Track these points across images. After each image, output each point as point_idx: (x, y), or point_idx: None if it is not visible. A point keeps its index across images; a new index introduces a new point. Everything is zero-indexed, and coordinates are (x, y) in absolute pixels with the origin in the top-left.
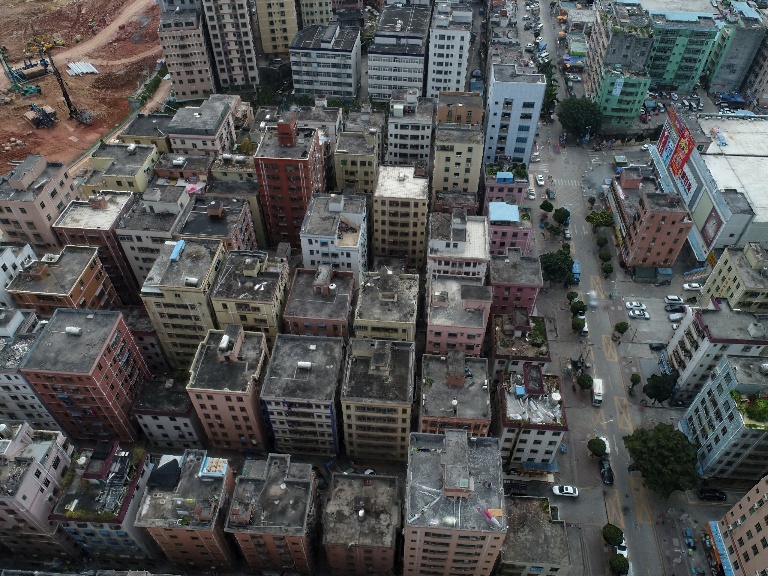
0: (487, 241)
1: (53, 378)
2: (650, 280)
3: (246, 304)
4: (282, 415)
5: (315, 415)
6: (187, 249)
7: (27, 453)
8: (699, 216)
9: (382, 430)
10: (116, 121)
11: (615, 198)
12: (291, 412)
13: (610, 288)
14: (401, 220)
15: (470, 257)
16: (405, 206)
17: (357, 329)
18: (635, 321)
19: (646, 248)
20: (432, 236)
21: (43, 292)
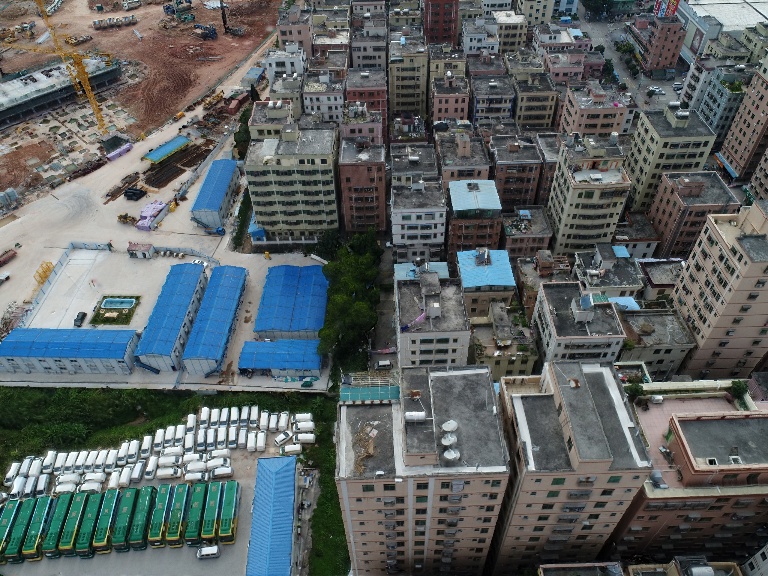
0: (572, 36)
1: (363, 94)
2: (662, 78)
3: (450, 63)
4: (483, 112)
5: (502, 110)
6: (407, 42)
7: None
8: (688, 39)
9: (537, 118)
10: (259, 33)
11: (633, 35)
12: (489, 109)
13: (638, 83)
14: (511, 40)
15: (565, 42)
16: (514, 29)
17: (510, 77)
18: (657, 96)
19: (658, 54)
20: (541, 33)
21: (330, 68)
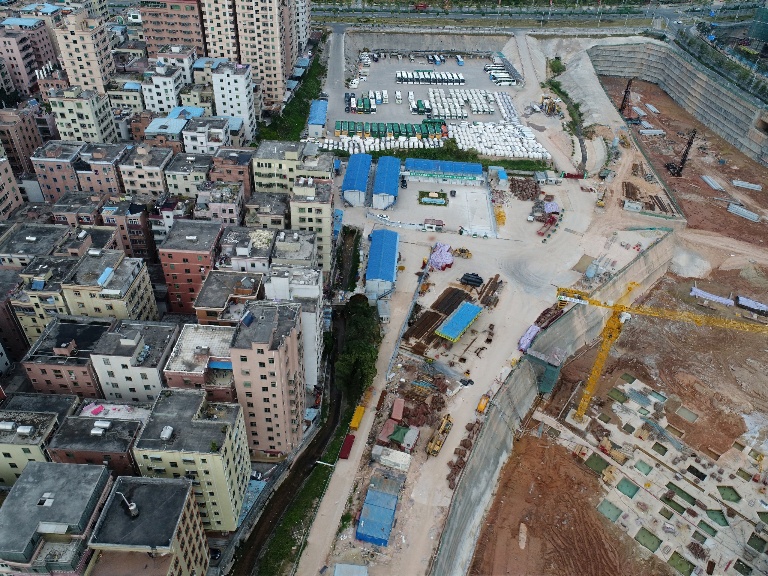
0: None
1: None
2: None
3: None
4: None
5: None
6: None
7: (207, 199)
8: None
9: None
10: None
11: None
12: None
13: None
14: None
15: None
16: None
17: None
18: None
19: None
20: None
21: (232, 274)
